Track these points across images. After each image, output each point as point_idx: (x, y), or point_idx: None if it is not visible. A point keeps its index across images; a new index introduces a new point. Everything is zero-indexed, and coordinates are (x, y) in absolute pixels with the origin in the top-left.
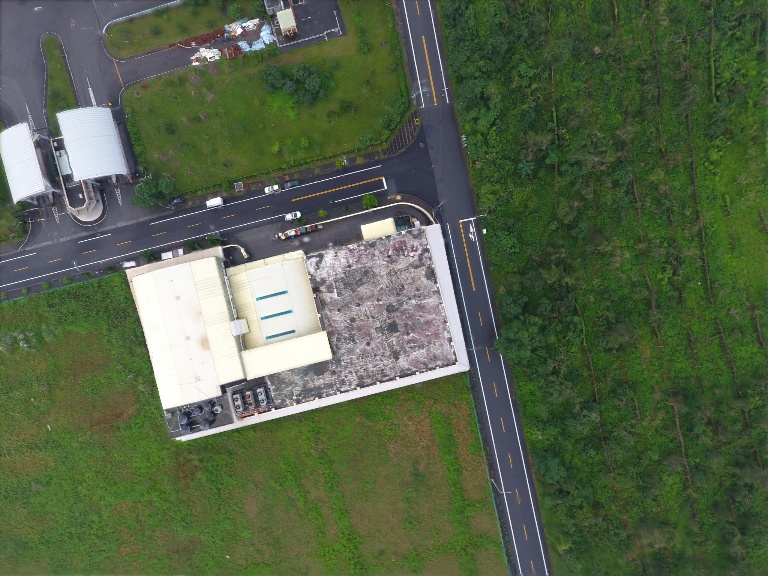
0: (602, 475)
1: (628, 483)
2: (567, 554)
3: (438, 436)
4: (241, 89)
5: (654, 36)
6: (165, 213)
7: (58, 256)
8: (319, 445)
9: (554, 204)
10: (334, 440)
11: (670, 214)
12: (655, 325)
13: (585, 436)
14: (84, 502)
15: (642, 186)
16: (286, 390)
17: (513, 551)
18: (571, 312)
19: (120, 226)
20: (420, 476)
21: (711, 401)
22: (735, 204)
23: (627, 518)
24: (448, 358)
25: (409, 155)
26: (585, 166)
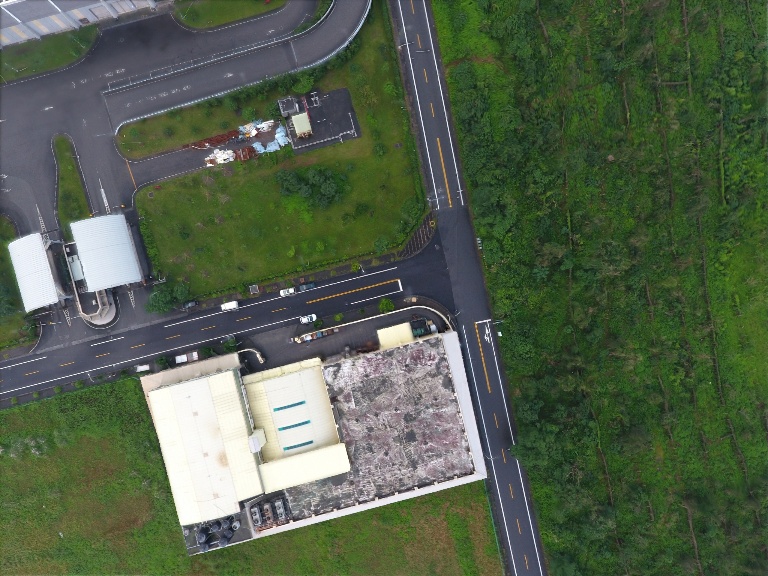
0: None
1: None
2: None
3: (455, 539)
4: (256, 191)
5: (665, 140)
6: (179, 316)
7: (70, 360)
8: (336, 549)
9: (568, 307)
10: (351, 544)
11: (682, 315)
12: (668, 427)
13: None
14: None
15: (654, 288)
16: (304, 501)
17: None
18: (586, 416)
19: (133, 329)
20: None
21: (723, 501)
22: (744, 304)
23: None
24: (466, 467)
25: (424, 257)
26: (600, 274)
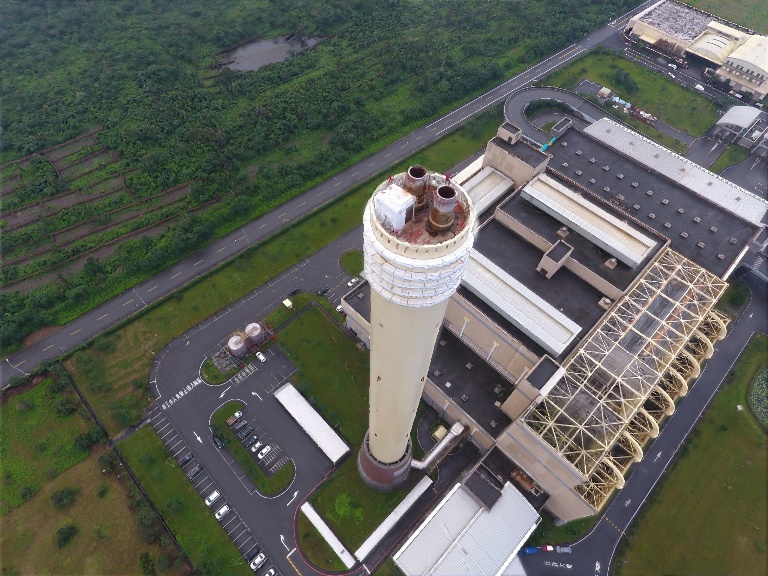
0: None
1: None
2: None
3: None
4: None
5: (493, 5)
6: None
7: None
8: None
9: None
10: None
11: None
12: None
13: None
14: None
15: None
16: None
17: None
18: None
19: None
20: None
21: None
22: None
23: None
24: (670, 2)
25: None
26: None
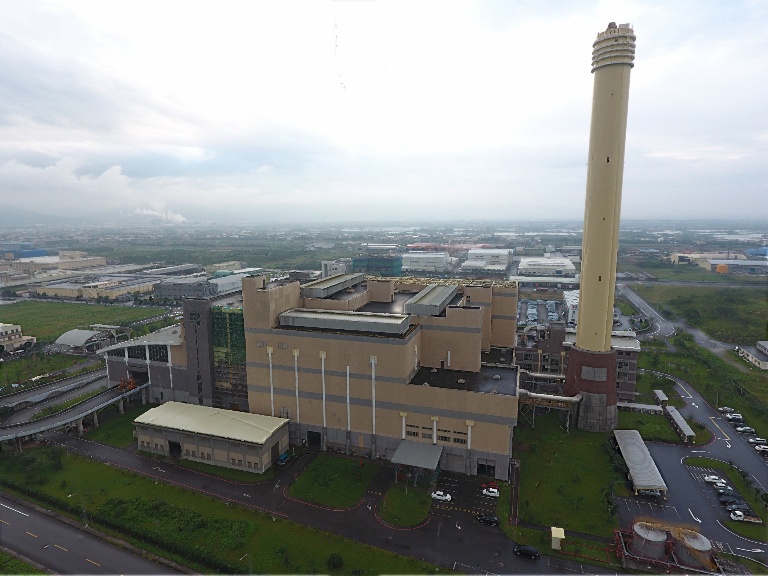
0: None
1: None
2: None
3: None
4: None
5: None
6: None
7: None
8: None
9: None
10: None
11: None
12: None
13: None
14: None
15: None
16: None
17: None
18: None
19: None
20: None
21: None
22: None
23: None
24: None
25: None
26: None
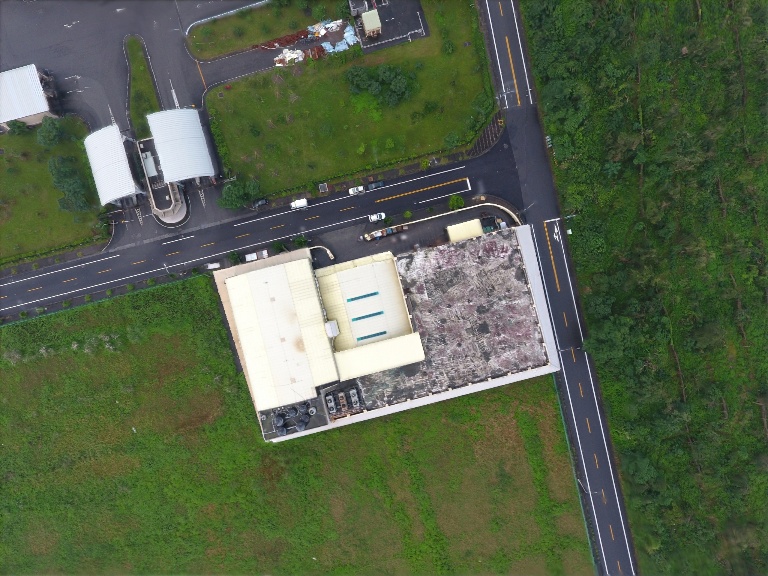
0: (689, 475)
1: (716, 483)
2: (657, 554)
3: (524, 437)
4: (325, 90)
5: (738, 36)
6: (249, 215)
7: (142, 258)
8: (405, 446)
9: (639, 204)
10: (420, 441)
11: (754, 214)
12: (741, 325)
13: (671, 436)
14: (170, 504)
15: (726, 186)
16: (377, 391)
17: (599, 551)
18: (658, 312)
19: (204, 228)
20: (506, 477)
21: None
22: None
23: (714, 518)
24: (539, 359)
25: (493, 156)
26: (674, 166)
